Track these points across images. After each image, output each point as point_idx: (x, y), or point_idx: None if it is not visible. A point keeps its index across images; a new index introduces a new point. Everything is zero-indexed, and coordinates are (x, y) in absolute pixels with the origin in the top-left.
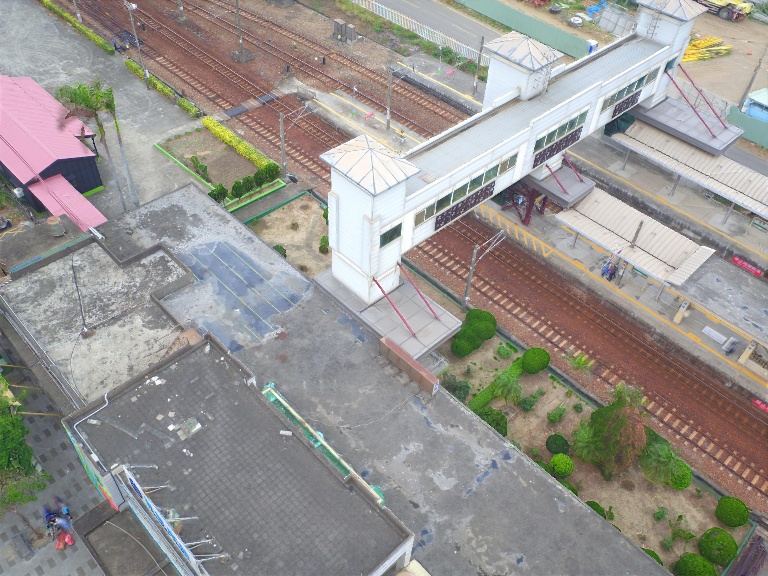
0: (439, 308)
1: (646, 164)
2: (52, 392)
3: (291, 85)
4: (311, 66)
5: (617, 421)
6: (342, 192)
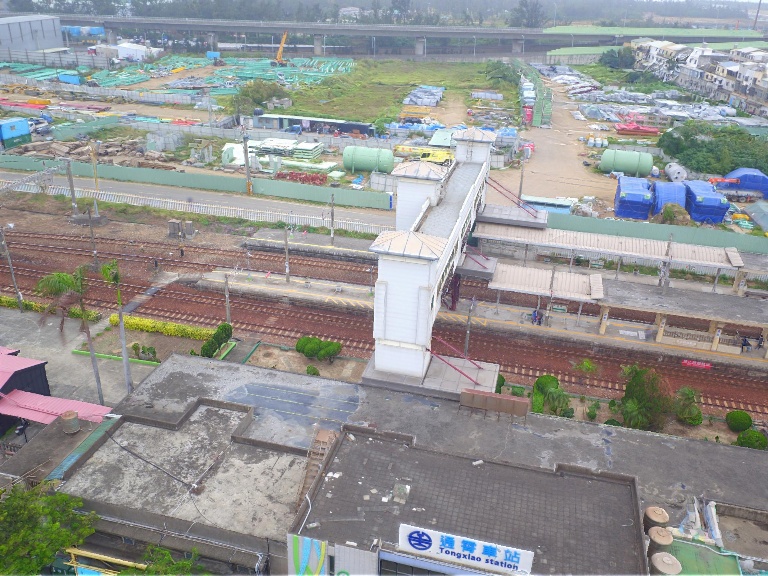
0: (474, 362)
1: (491, 255)
2: (206, 551)
3: (166, 276)
4: (171, 260)
5: (650, 382)
6: (392, 276)
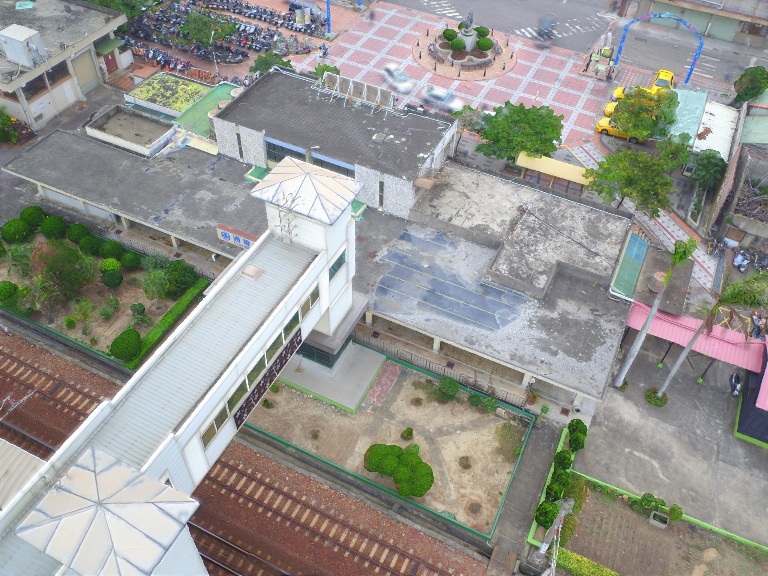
0: None
1: None
2: None
3: None
4: None
5: None
6: None
